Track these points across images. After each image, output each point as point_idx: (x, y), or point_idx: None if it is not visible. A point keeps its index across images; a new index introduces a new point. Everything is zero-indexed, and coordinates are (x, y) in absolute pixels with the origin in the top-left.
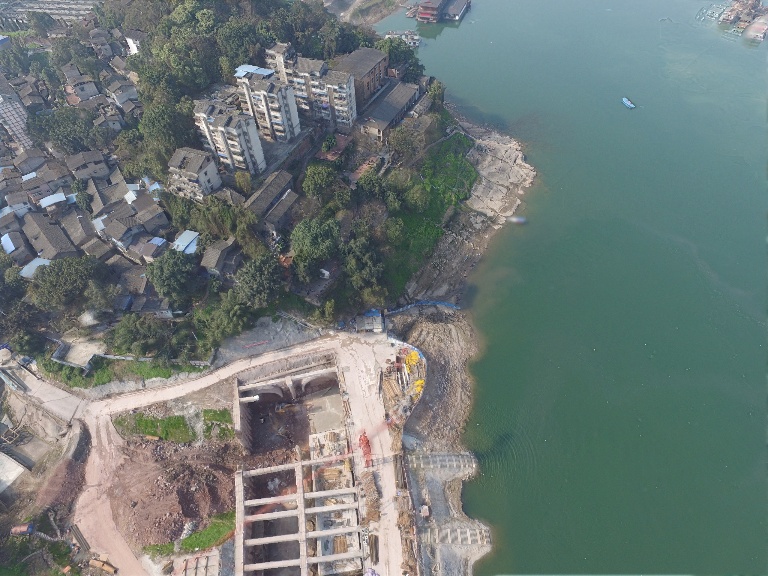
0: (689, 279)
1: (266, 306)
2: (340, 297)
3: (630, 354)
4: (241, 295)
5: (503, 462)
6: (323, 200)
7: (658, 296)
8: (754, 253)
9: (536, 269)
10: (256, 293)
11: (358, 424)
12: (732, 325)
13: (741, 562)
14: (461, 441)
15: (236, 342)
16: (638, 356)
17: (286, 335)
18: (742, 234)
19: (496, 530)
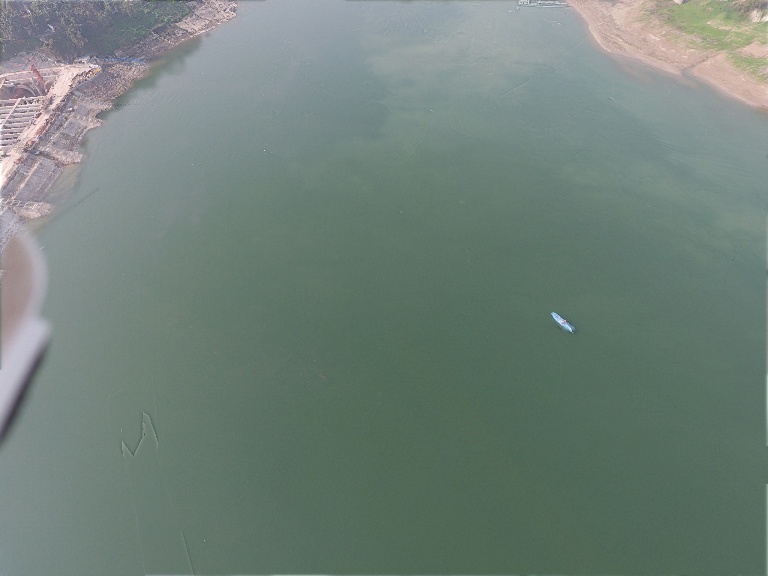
0: (278, 50)
1: (12, 35)
2: (62, 43)
3: (220, 75)
4: (4, 34)
5: (127, 106)
6: (65, 3)
7: (256, 57)
8: (327, 41)
9: (200, 50)
10: (6, 27)
11: (55, 88)
12: (286, 65)
13: (209, 125)
14: (111, 101)
15: (7, 64)
16: (224, 75)
17: (35, 62)
18: (330, 35)
19: (107, 122)
